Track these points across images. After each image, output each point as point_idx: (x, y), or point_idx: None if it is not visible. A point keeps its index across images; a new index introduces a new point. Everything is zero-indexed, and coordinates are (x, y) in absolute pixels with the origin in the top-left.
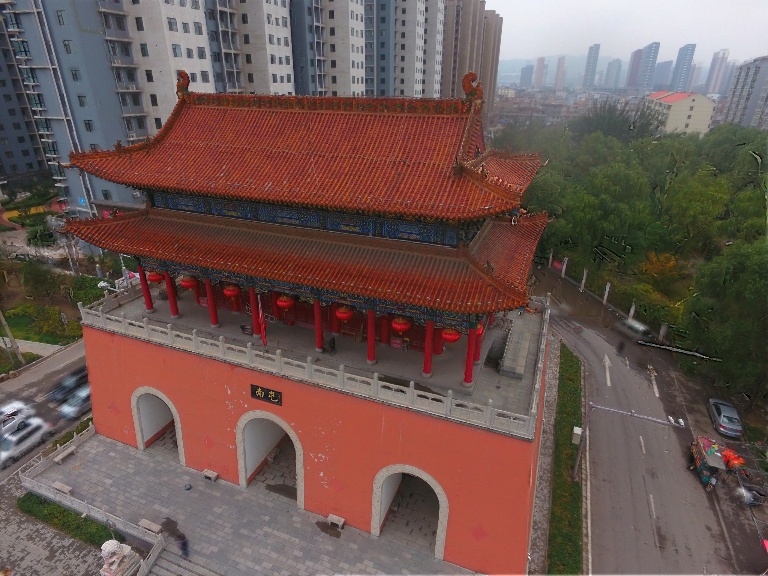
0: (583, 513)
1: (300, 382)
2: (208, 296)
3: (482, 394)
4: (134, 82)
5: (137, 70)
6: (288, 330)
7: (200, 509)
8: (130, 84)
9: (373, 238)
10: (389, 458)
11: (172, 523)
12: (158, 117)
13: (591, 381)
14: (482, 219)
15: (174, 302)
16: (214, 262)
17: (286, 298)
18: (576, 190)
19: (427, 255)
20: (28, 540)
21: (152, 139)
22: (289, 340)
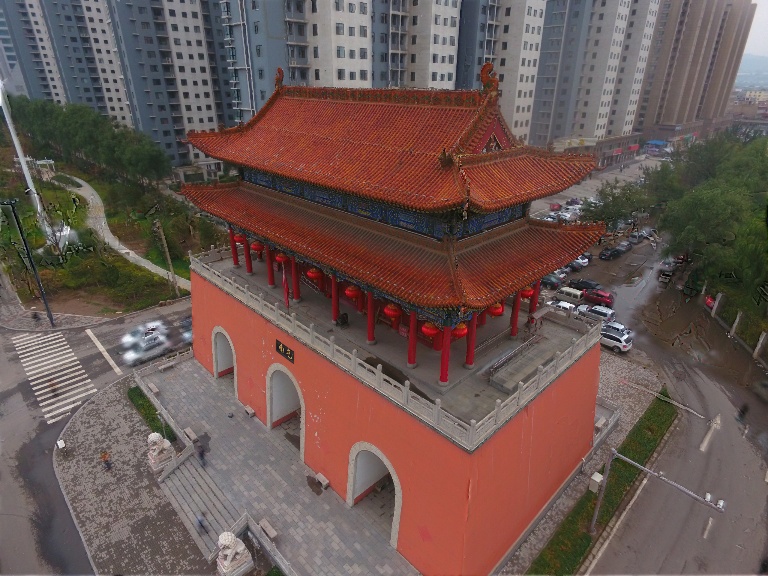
0: (580, 570)
1: (305, 345)
2: (267, 260)
3: (455, 397)
4: (306, 80)
5: (309, 70)
6: (324, 301)
7: (230, 434)
8: (301, 82)
9: (378, 223)
10: (361, 434)
11: (207, 438)
12: None
13: (679, 438)
14: (441, 211)
15: (249, 261)
16: (260, 229)
17: (315, 270)
18: (754, 213)
19: (418, 246)
20: (123, 418)
21: (246, 124)
22: (318, 309)
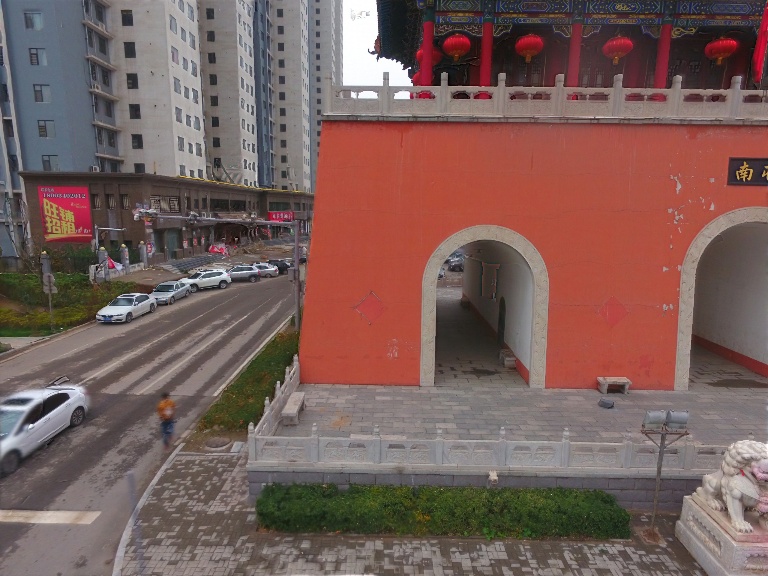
0: None
1: None
2: (576, 58)
3: None
4: None
5: (107, 9)
6: None
7: None
8: (99, 21)
9: None
10: None
11: None
12: (133, 72)
13: None
14: None
15: None
16: None
17: None
18: None
19: None
20: None
21: None
22: None
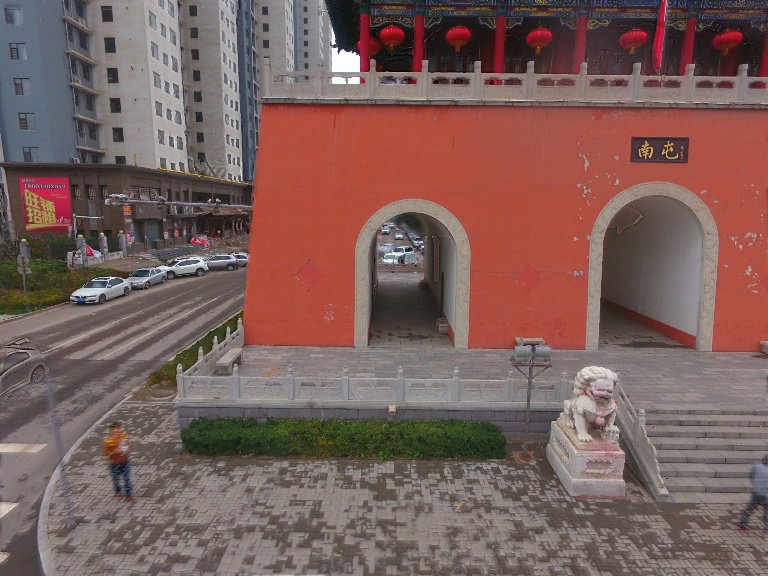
0: None
1: (726, 109)
2: (500, 48)
3: None
4: None
5: (87, 6)
6: None
7: None
8: (79, 17)
9: None
10: None
11: None
12: (113, 67)
13: None
14: None
15: None
16: None
17: None
18: None
19: None
20: (285, 485)
21: None
22: None
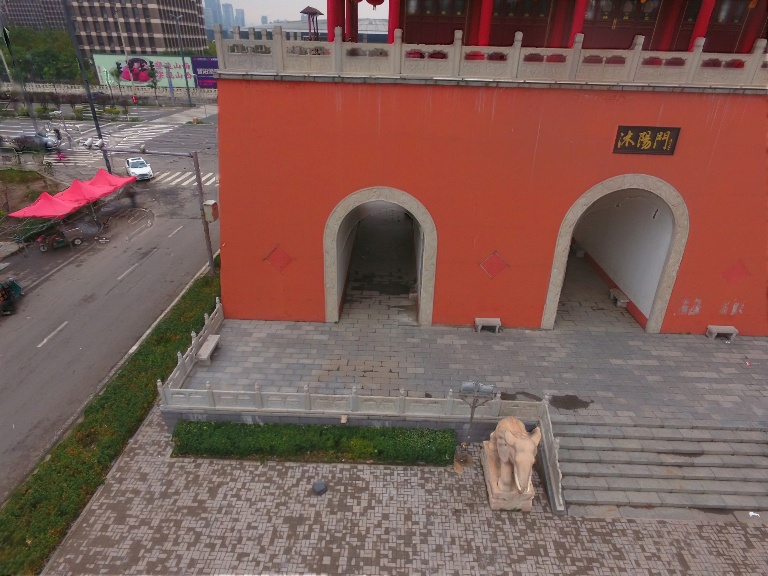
0: None
1: None
2: None
3: None
4: None
5: None
6: None
7: None
8: None
9: None
10: None
11: None
12: None
13: (8, 475)
14: None
15: None
16: None
17: None
18: None
19: None
20: None
21: None
22: None
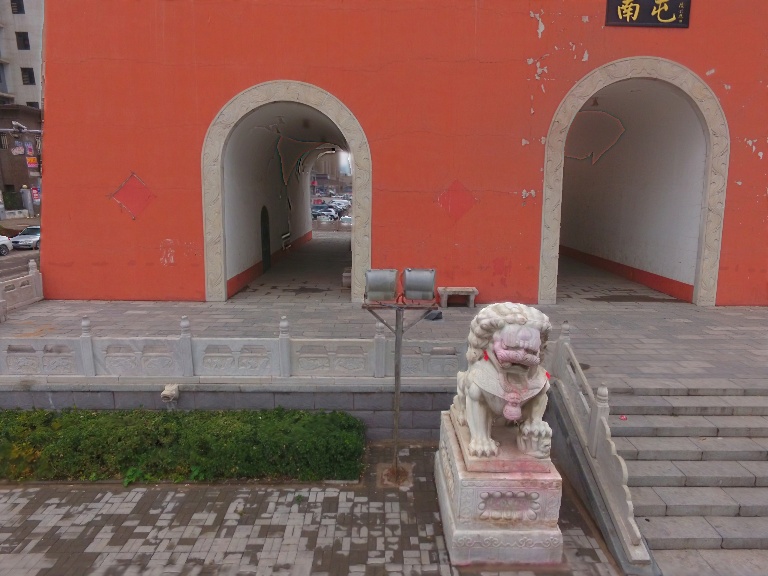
0: None
1: None
2: None
3: None
4: None
5: None
6: None
7: None
8: None
9: None
10: None
11: None
12: None
13: None
14: None
15: None
16: None
17: None
18: None
19: None
20: None
21: None
22: None
